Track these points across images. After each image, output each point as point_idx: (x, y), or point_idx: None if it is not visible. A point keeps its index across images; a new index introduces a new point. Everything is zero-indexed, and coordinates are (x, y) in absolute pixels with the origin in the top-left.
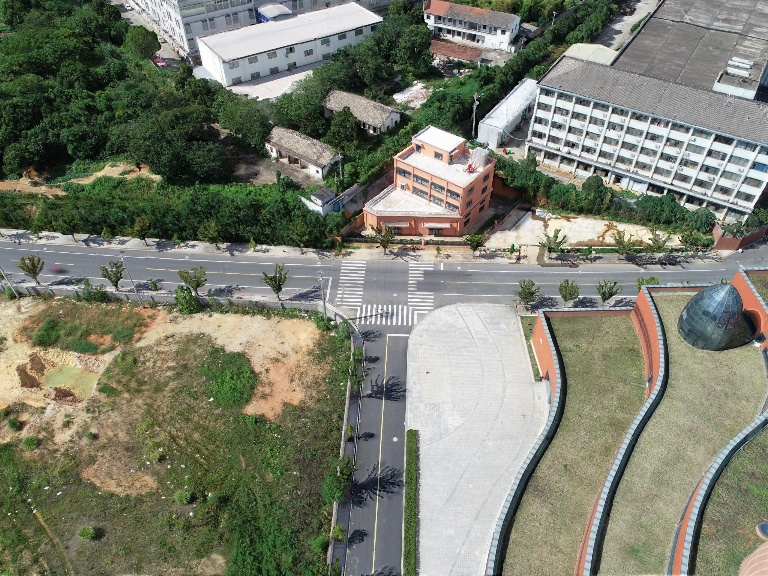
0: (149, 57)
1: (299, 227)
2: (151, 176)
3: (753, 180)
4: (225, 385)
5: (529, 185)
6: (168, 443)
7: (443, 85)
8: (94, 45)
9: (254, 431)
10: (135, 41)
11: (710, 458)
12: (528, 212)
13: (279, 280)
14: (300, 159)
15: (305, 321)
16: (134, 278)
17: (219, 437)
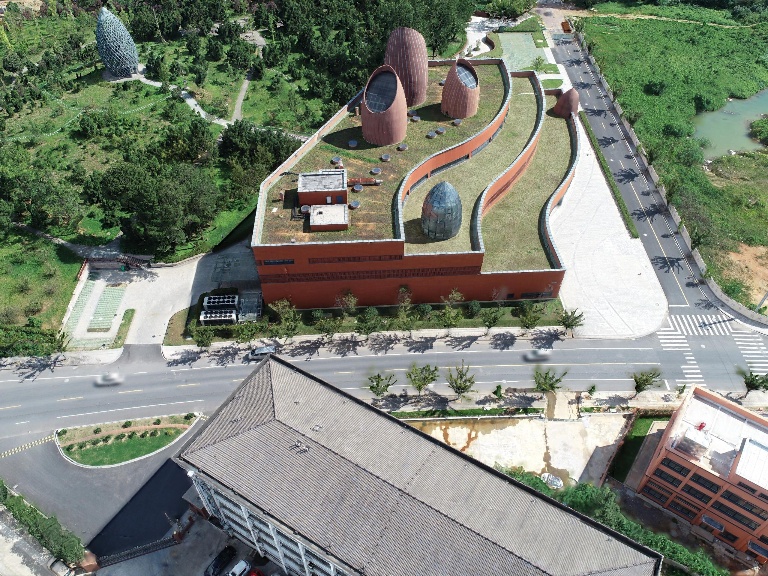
0: None
1: None
2: None
3: None
4: None
5: None
6: None
7: None
8: None
9: None
10: None
11: (464, 164)
12: None
13: None
14: None
15: None
16: None
17: None
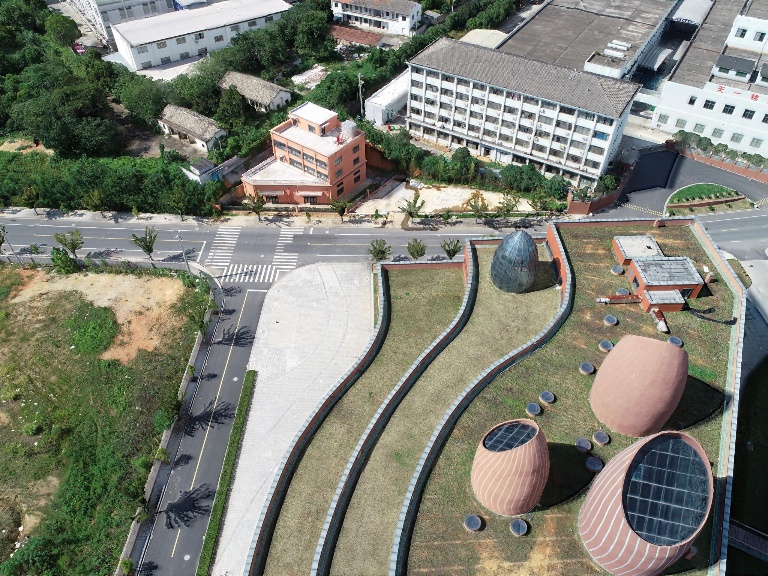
0: (69, 44)
1: (177, 195)
2: (46, 151)
3: (597, 148)
4: (87, 334)
5: (401, 157)
6: (25, 384)
7: (341, 68)
8: (16, 33)
9: (106, 373)
10: (53, 28)
11: None
12: (403, 182)
13: (149, 242)
14: (187, 134)
15: (173, 279)
16: (20, 243)
17: (73, 379)
